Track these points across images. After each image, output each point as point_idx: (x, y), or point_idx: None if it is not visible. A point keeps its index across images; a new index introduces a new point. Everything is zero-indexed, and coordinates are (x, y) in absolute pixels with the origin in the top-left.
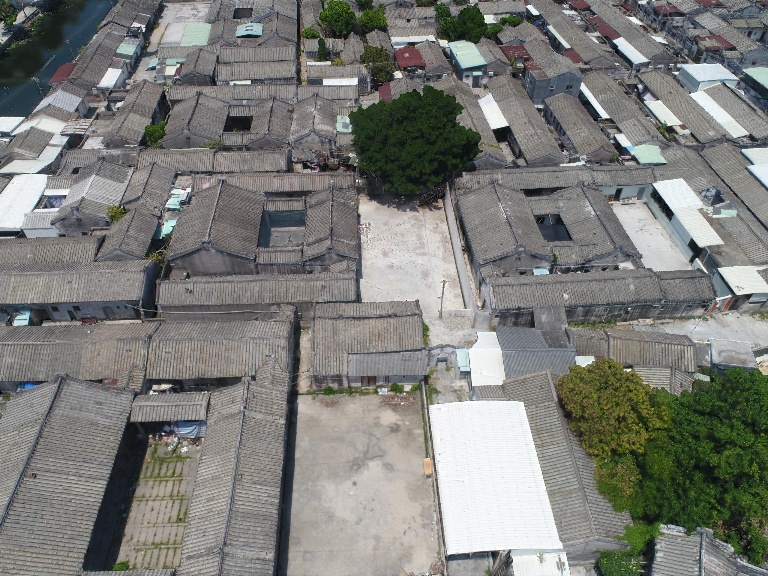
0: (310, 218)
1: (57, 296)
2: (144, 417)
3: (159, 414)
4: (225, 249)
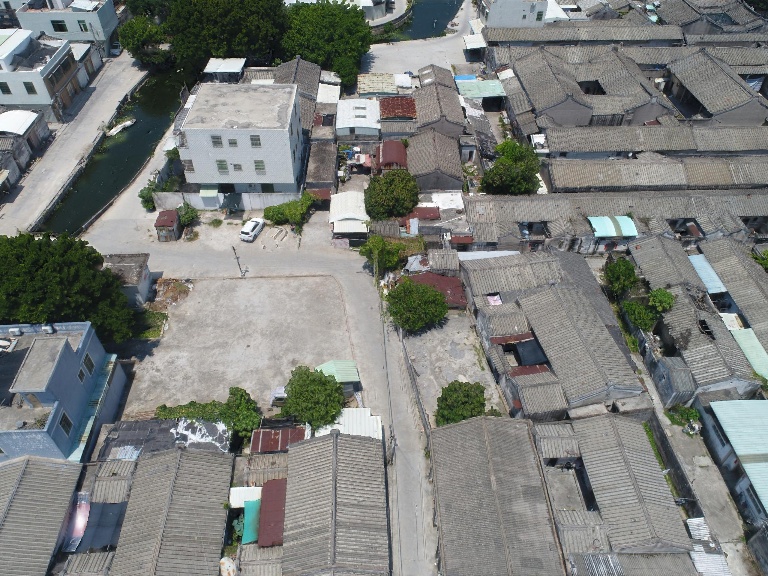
0: (733, 15)
1: (639, 37)
2: (739, 72)
3: (746, 71)
4: (711, 20)
